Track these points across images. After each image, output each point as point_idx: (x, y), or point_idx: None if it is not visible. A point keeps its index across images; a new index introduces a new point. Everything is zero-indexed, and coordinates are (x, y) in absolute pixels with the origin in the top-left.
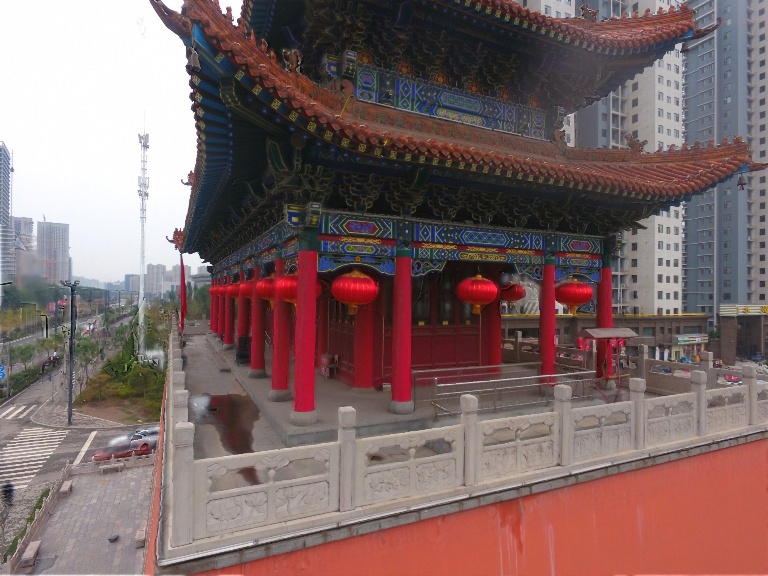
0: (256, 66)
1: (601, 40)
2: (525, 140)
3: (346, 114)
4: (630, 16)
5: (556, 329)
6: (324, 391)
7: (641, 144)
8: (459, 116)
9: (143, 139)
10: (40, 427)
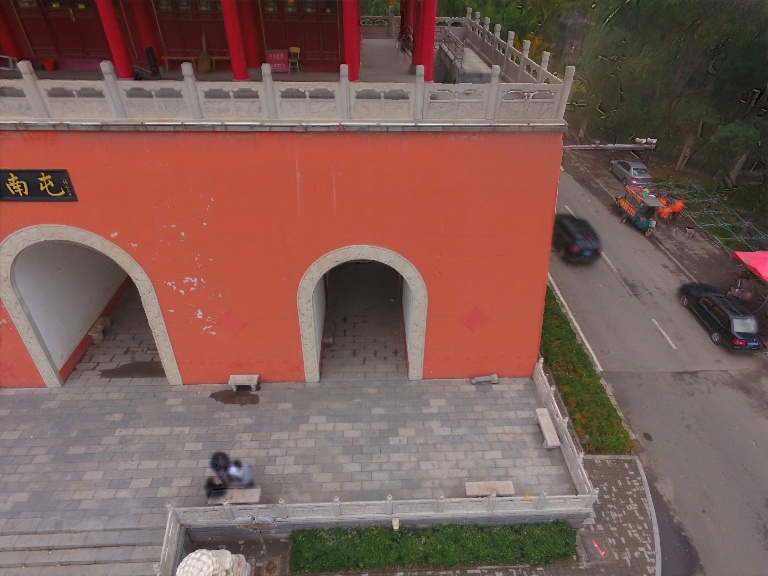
0: None
1: None
2: None
3: None
4: None
5: None
6: (337, 78)
7: None
8: None
9: None
10: None
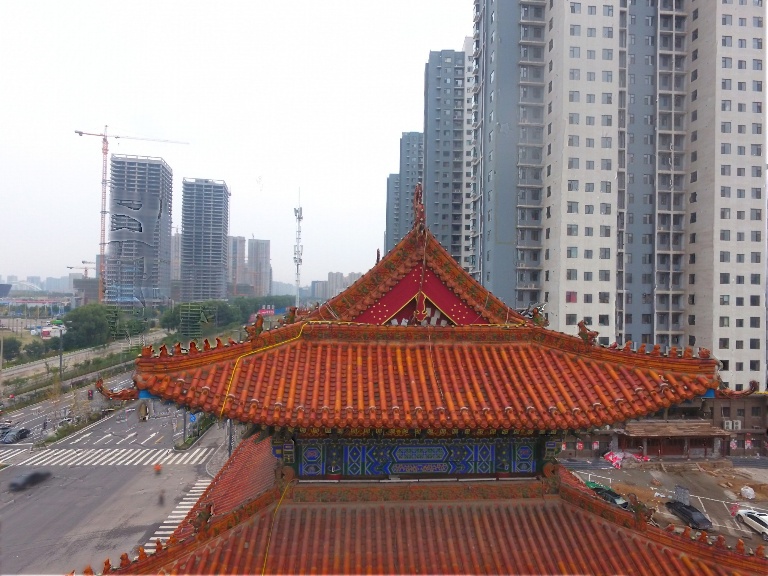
0: None
1: (564, 425)
2: (500, 485)
3: (286, 500)
4: (635, 348)
5: (739, 409)
6: None
7: (647, 513)
8: (419, 467)
9: (298, 212)
10: (209, 479)
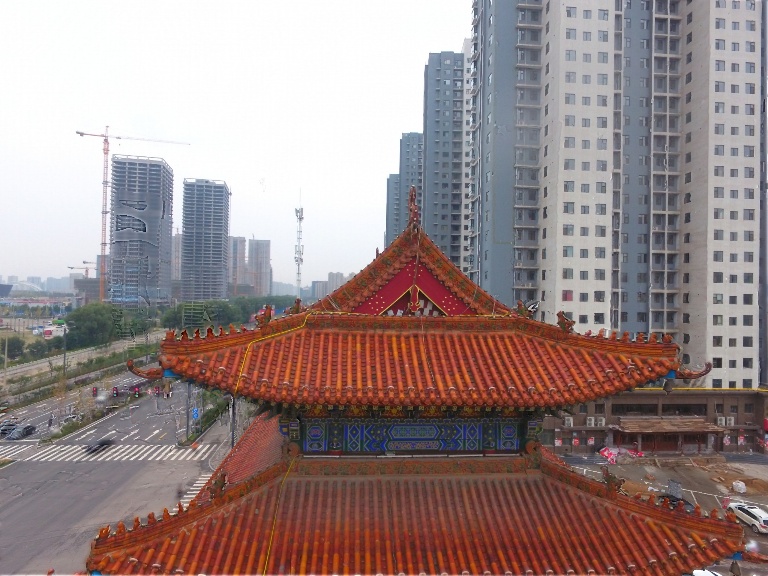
0: (151, 565)
1: (542, 403)
2: (486, 461)
3: (292, 474)
4: (607, 335)
5: (732, 406)
6: None
7: (617, 483)
8: (412, 444)
9: (299, 212)
10: None
